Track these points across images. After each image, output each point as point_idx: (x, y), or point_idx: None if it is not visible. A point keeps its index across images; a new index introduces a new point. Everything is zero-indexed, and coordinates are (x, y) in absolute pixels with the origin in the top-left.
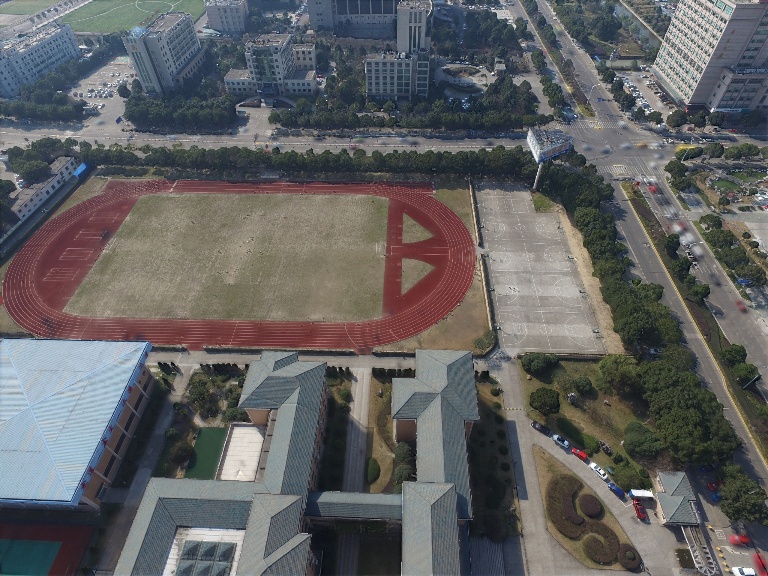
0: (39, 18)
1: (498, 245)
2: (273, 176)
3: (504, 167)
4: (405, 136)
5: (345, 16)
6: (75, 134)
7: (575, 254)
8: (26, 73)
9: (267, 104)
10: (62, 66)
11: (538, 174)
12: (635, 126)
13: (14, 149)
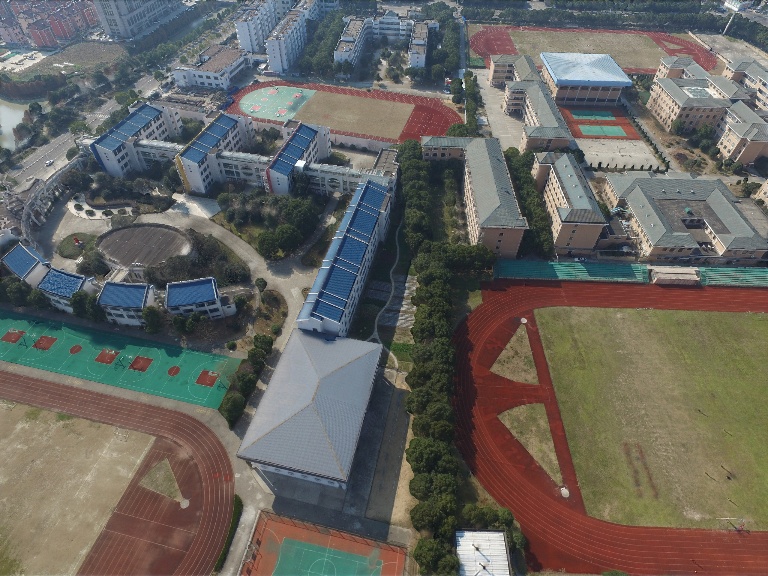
0: None
1: (720, 51)
2: (575, 26)
3: (708, 21)
4: None
5: None
6: None
7: (761, 54)
8: None
9: None
10: None
11: (729, 24)
12: (762, 15)
13: (428, 5)
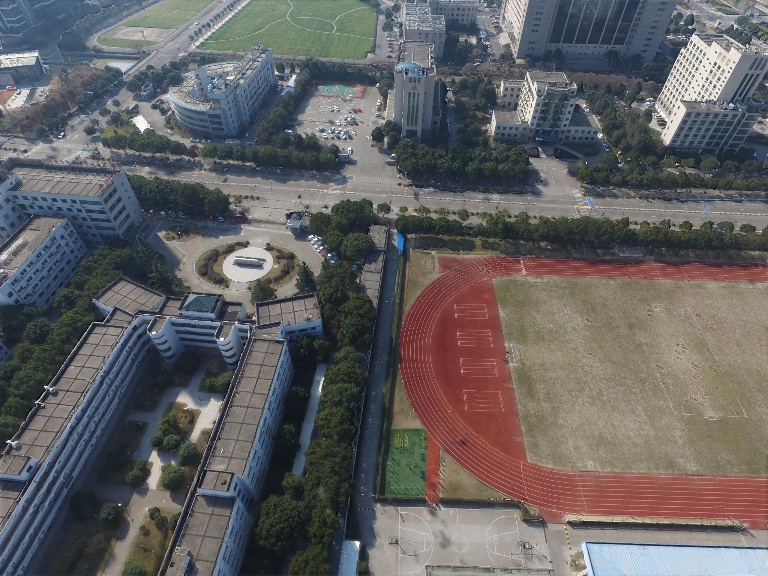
0: (196, 35)
1: None
2: (636, 254)
3: None
4: (741, 200)
5: (556, 45)
6: (345, 189)
7: None
8: (245, 108)
9: (547, 154)
10: (285, 100)
11: None
12: None
13: (322, 216)
